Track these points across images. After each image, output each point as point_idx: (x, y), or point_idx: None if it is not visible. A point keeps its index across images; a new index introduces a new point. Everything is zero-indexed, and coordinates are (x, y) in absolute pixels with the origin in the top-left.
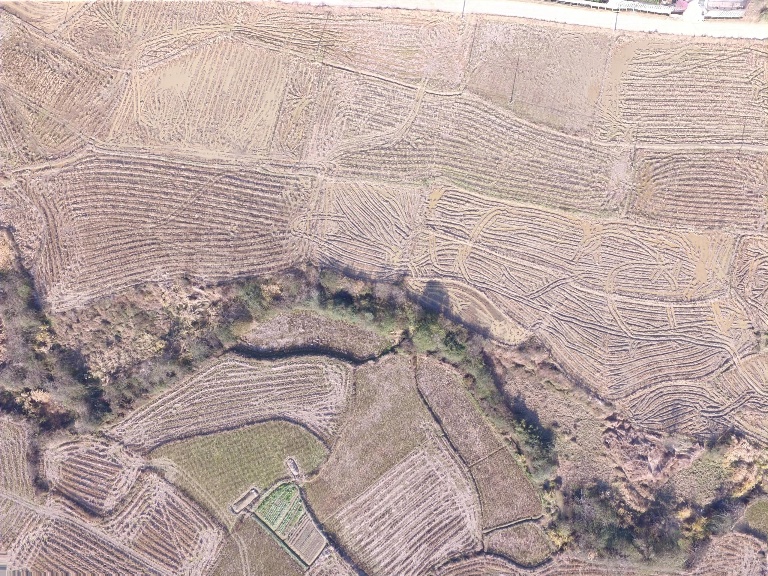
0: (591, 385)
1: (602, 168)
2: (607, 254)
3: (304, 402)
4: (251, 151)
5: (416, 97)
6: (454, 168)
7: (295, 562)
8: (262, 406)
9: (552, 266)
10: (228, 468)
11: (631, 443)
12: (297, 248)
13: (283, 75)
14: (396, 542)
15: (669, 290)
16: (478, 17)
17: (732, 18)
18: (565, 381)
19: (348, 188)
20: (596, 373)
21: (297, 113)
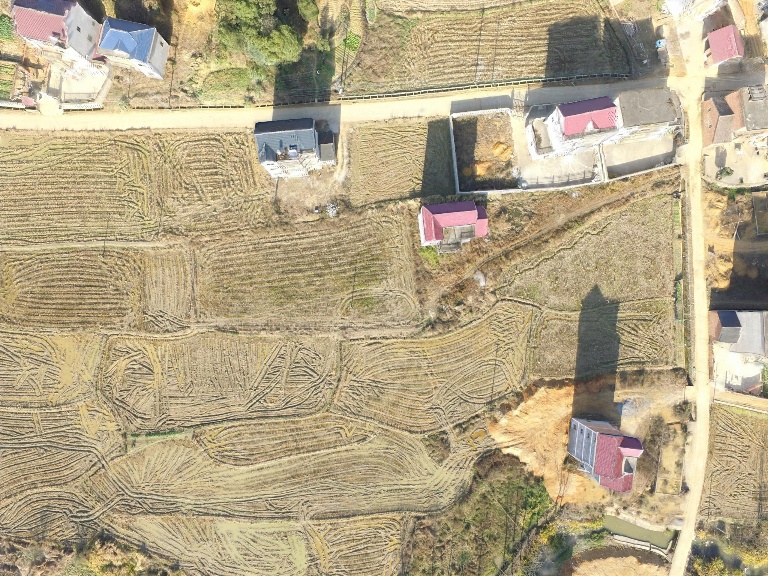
0: None
1: None
2: None
3: None
4: None
5: None
6: None
7: None
8: None
9: None
10: None
11: None
12: None
13: None
14: None
15: (34, 396)
16: None
17: (93, 110)
18: None
19: None
20: None
21: None
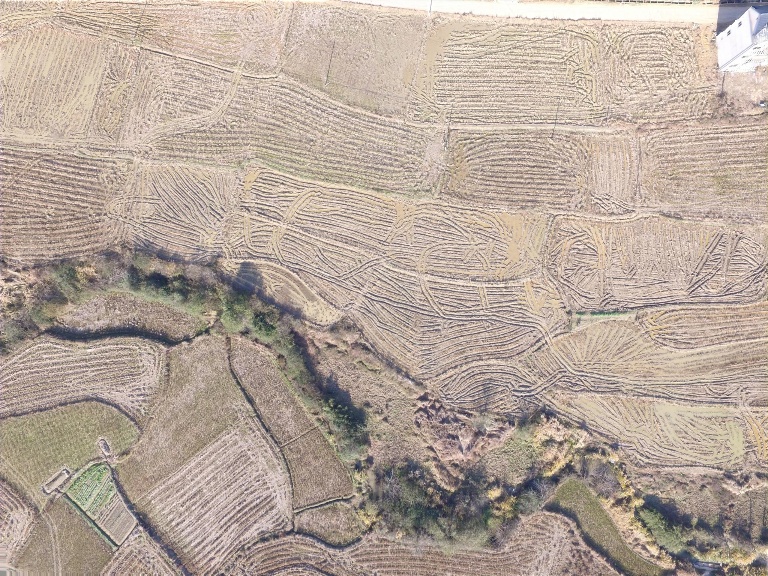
0: (402, 365)
1: (416, 149)
2: (420, 234)
3: (117, 383)
4: (69, 135)
5: (233, 80)
6: (268, 150)
7: (105, 542)
8: (76, 387)
9: (365, 247)
10: (40, 449)
11: (441, 422)
12: (112, 230)
13: (102, 60)
14: (207, 522)
15: (481, 270)
16: (294, 1)
17: None
18: (376, 361)
19: (164, 171)
20: (407, 353)
21: (115, 97)
